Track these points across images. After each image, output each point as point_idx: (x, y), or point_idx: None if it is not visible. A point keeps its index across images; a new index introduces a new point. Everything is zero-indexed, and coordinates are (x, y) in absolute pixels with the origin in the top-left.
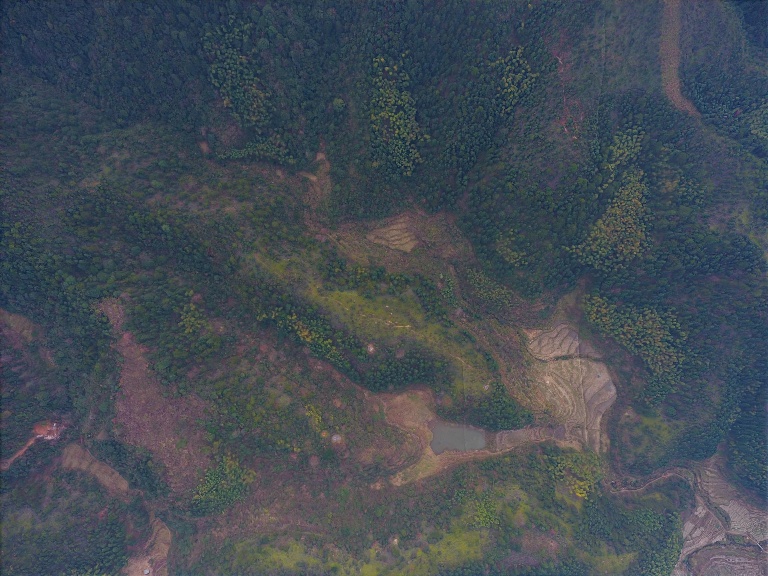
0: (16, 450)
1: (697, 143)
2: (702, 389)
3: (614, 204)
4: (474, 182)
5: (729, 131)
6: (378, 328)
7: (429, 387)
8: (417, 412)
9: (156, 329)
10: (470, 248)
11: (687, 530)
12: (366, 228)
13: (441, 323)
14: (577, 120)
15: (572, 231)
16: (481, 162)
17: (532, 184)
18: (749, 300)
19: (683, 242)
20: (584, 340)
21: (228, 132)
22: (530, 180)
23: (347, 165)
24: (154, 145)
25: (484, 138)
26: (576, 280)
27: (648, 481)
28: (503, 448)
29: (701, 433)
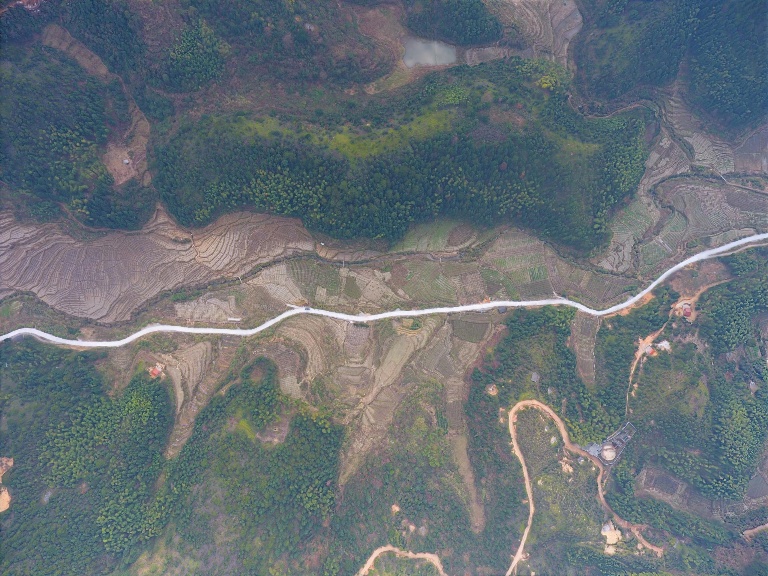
0: None
1: None
2: None
3: None
4: None
5: None
6: None
7: None
8: (389, 27)
9: None
10: None
11: (653, 160)
12: None
13: None
14: None
15: None
16: None
17: None
18: None
19: None
20: None
21: None
22: None
23: None
24: None
25: None
26: None
27: (614, 109)
28: (473, 63)
29: (662, 29)
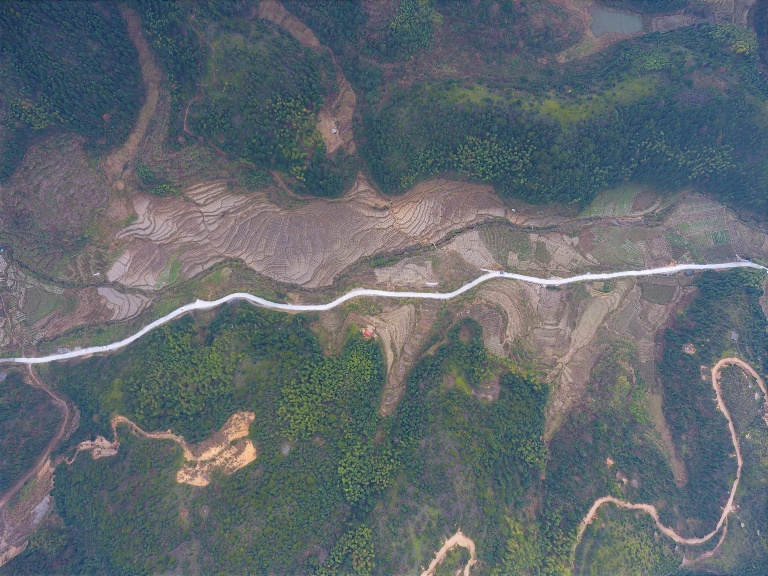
0: None
1: None
2: None
3: None
4: None
5: None
6: None
7: None
8: None
9: None
10: None
11: None
12: None
13: None
14: None
15: None
16: None
17: None
18: None
19: None
20: None
21: None
22: None
23: None
24: None
25: None
26: None
27: None
28: None
29: None
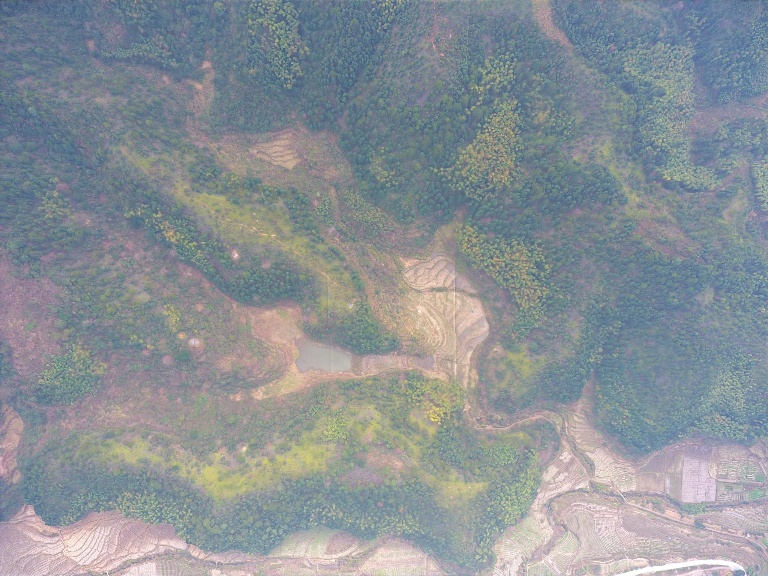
0: None
1: (567, 73)
2: (563, 324)
3: (485, 130)
4: (352, 99)
5: (599, 64)
6: (242, 233)
7: (298, 304)
8: (285, 329)
9: (14, 210)
10: (349, 169)
11: (551, 474)
12: (249, 141)
13: (309, 237)
14: (445, 37)
15: (438, 151)
16: (360, 80)
17: (401, 101)
18: (606, 232)
19: (547, 171)
20: (460, 274)
21: (114, 30)
22: (400, 97)
23: (227, 71)
24: (34, 33)
25: (362, 54)
26: (451, 209)
27: (515, 421)
28: (368, 372)
29: (560, 369)
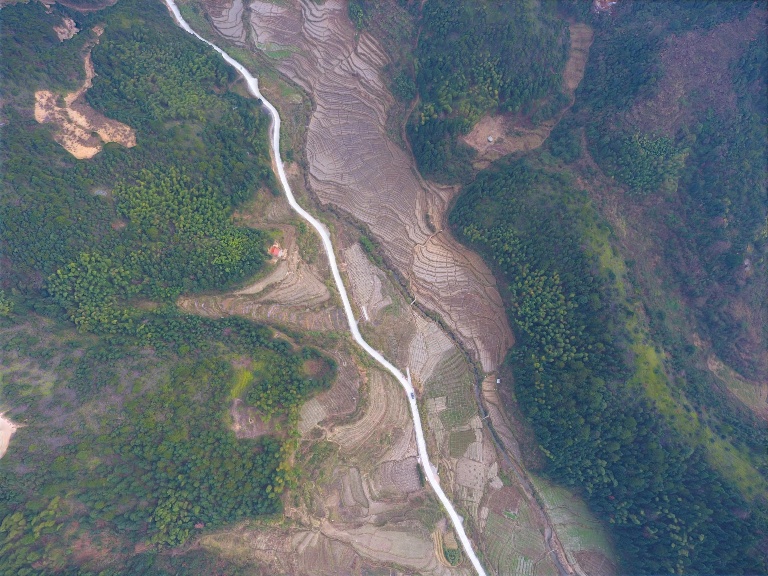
0: None
1: None
2: None
3: None
4: None
5: None
6: None
7: None
8: None
9: None
10: None
11: None
12: None
13: None
14: None
15: None
16: None
17: None
18: None
19: None
20: None
21: None
22: None
23: None
24: None
25: None
26: None
27: None
28: None
29: None
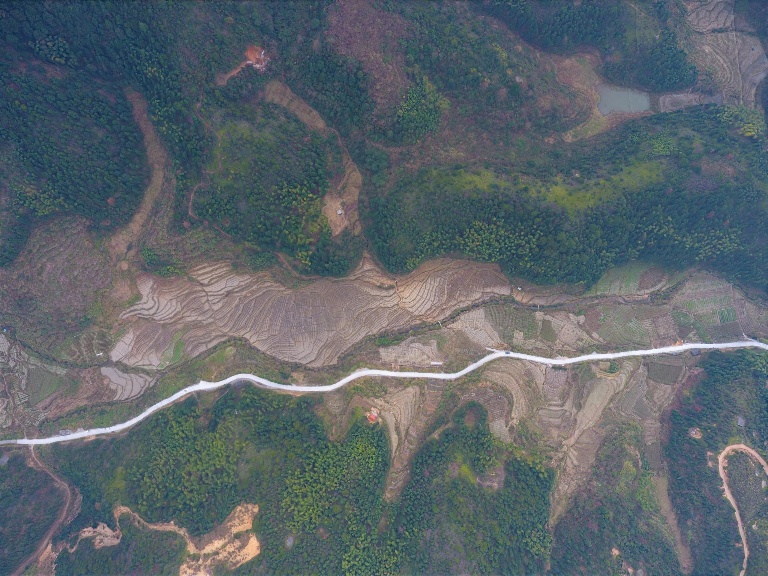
0: (233, 66)
1: None
2: None
3: None
4: None
5: None
6: None
7: (597, 49)
8: (585, 76)
9: None
10: None
11: None
12: None
13: None
14: None
15: None
16: None
17: None
18: None
19: None
20: (739, 13)
21: None
22: None
23: None
24: None
25: None
26: None
27: None
28: (666, 110)
29: None
